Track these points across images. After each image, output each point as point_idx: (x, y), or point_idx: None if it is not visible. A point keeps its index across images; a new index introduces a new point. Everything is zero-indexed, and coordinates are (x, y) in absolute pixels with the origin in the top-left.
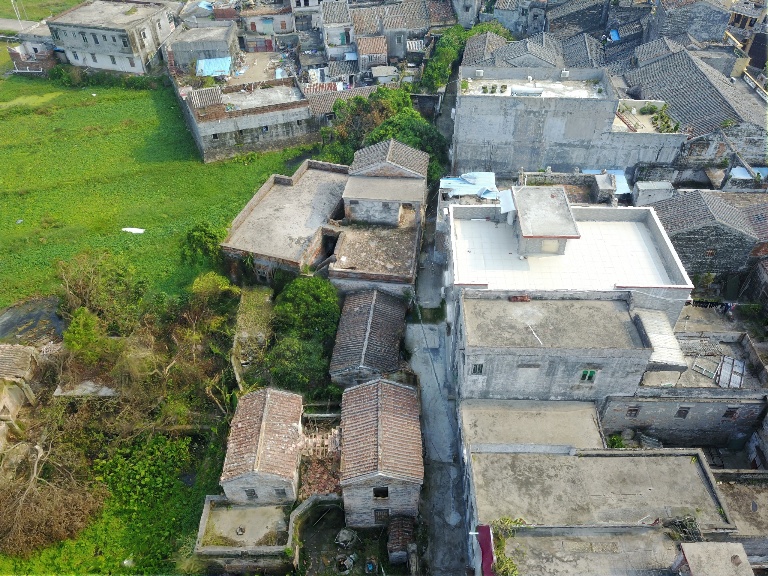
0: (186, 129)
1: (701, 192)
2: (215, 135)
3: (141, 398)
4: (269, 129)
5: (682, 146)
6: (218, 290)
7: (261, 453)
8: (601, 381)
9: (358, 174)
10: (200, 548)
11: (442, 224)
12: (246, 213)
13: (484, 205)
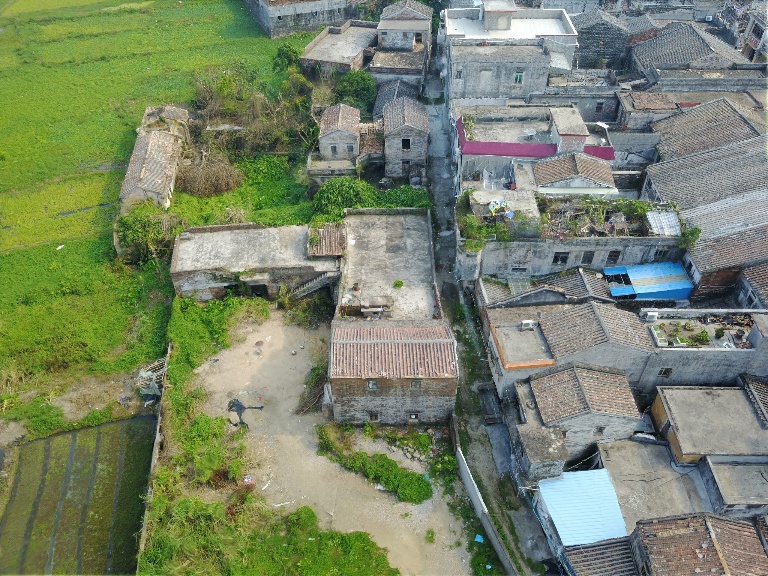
0: (254, 21)
1: (598, 9)
2: (280, 17)
3: (259, 131)
4: (318, 14)
5: (600, 2)
6: (298, 85)
7: (341, 124)
8: (526, 82)
9: (387, 18)
10: (309, 168)
11: (441, 38)
12: (313, 45)
13: (465, 9)
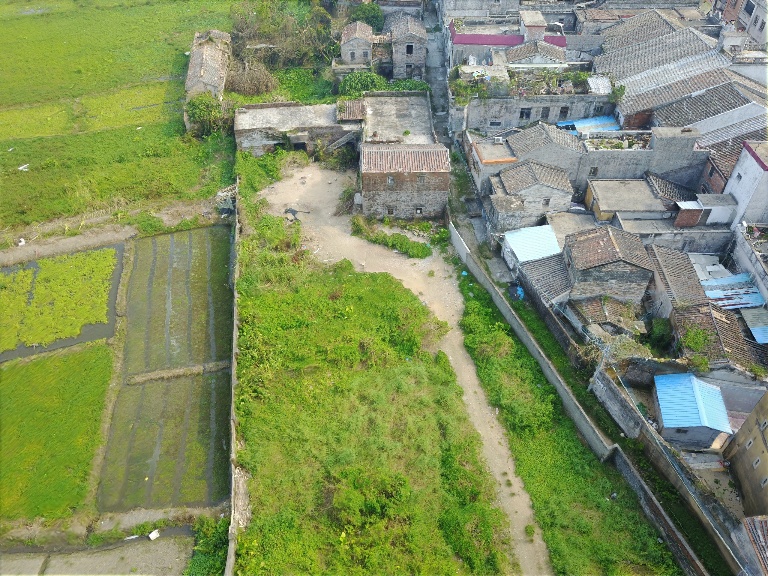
0: None
1: None
2: None
3: (290, 48)
4: None
5: None
6: (319, 16)
7: (358, 34)
8: (503, 1)
9: None
10: (334, 67)
11: None
12: None
13: None
